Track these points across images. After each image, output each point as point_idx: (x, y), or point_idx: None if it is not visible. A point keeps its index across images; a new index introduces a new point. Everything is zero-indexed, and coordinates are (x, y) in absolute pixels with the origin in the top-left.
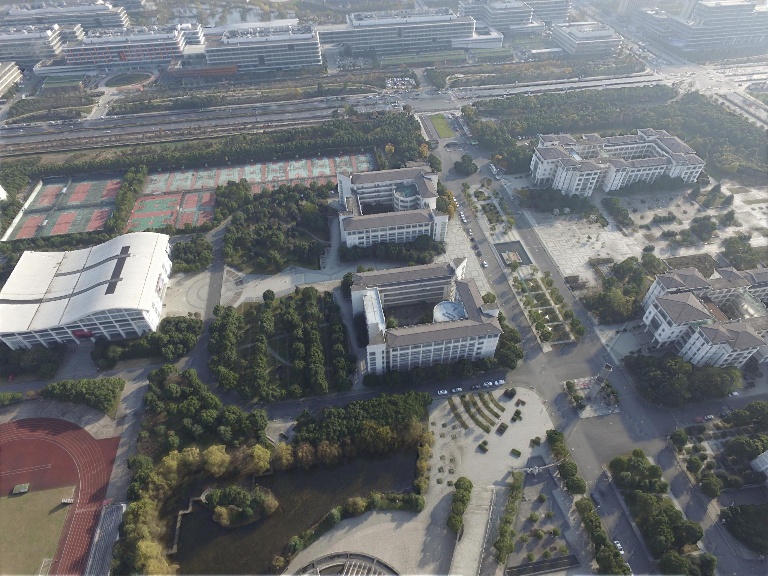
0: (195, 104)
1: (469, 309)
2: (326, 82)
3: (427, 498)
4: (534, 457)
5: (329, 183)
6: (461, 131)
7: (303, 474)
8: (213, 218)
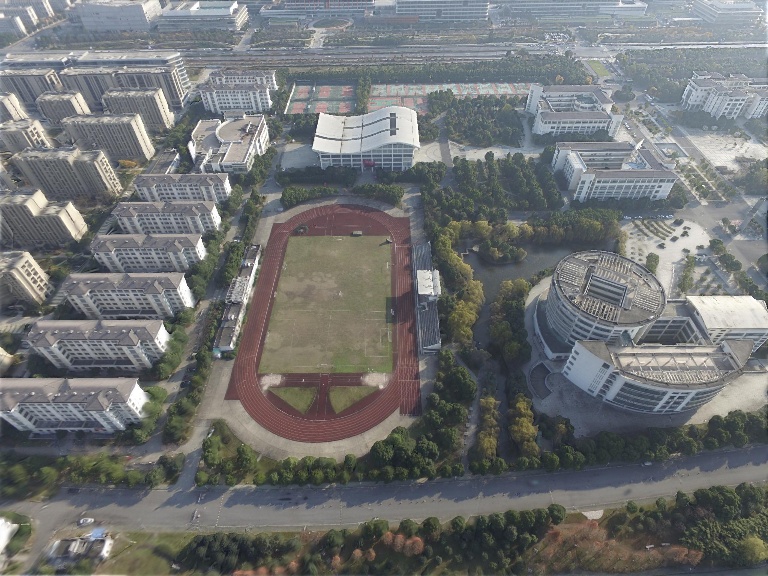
0: (392, 41)
1: (652, 164)
2: (493, 33)
3: None
4: (700, 254)
5: (516, 96)
6: (616, 73)
7: (537, 246)
8: (431, 112)
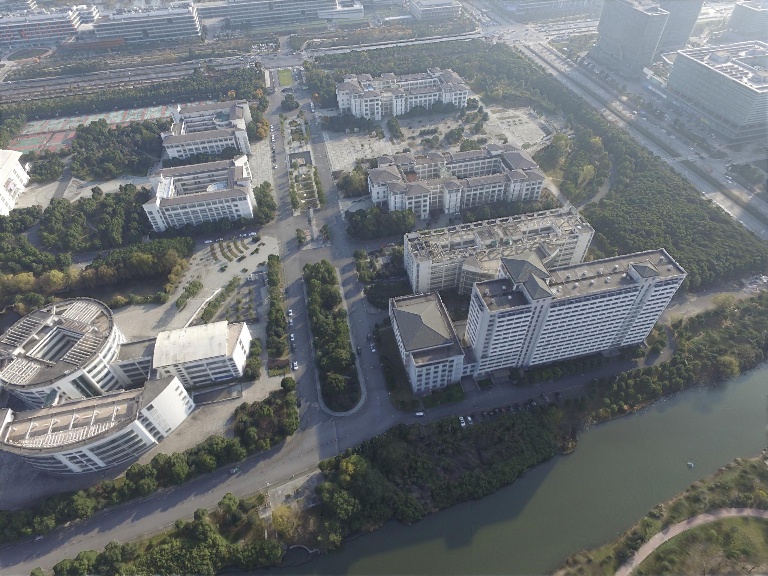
0: (80, 69)
1: (229, 183)
2: (200, 49)
3: (172, 297)
4: (256, 272)
5: (171, 119)
6: (299, 80)
7: (91, 290)
8: (71, 147)
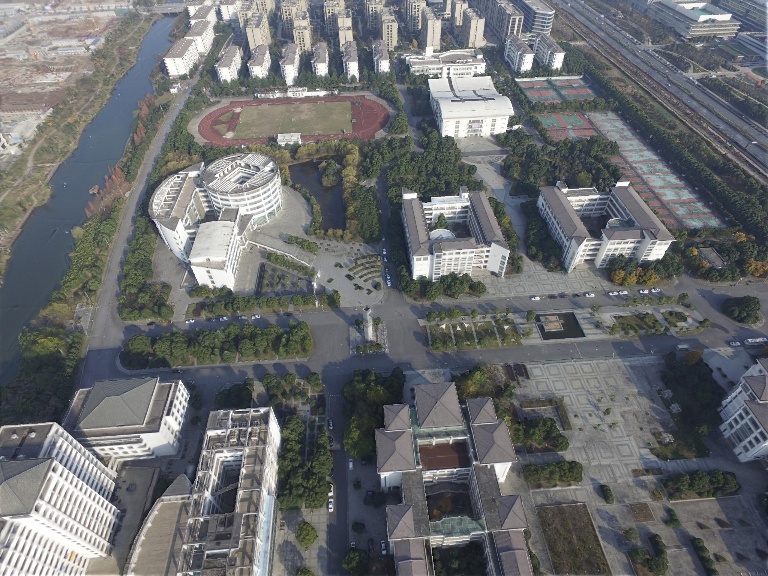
0: (749, 110)
1: (438, 240)
2: None
3: (313, 238)
4: (325, 289)
5: None
6: None
7: None
8: None
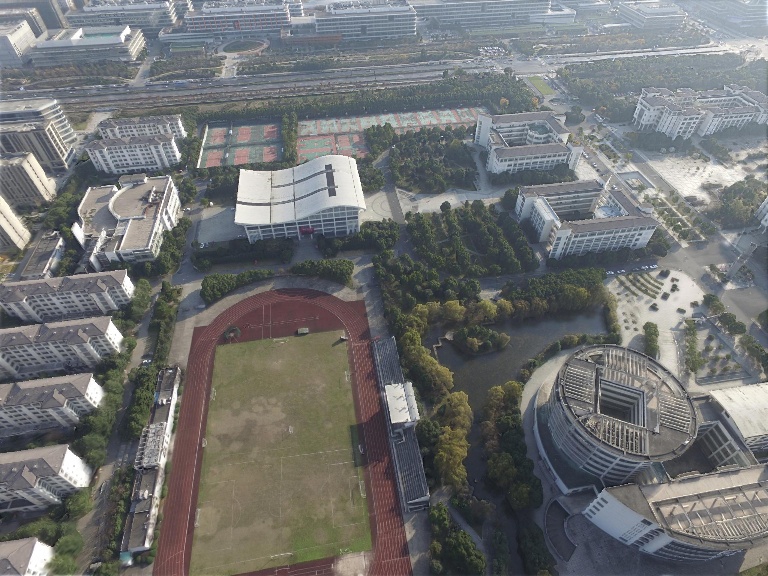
0: (316, 66)
1: (628, 208)
2: (425, 50)
3: None
4: (697, 313)
5: (463, 127)
6: (560, 90)
7: (518, 324)
8: (371, 153)
